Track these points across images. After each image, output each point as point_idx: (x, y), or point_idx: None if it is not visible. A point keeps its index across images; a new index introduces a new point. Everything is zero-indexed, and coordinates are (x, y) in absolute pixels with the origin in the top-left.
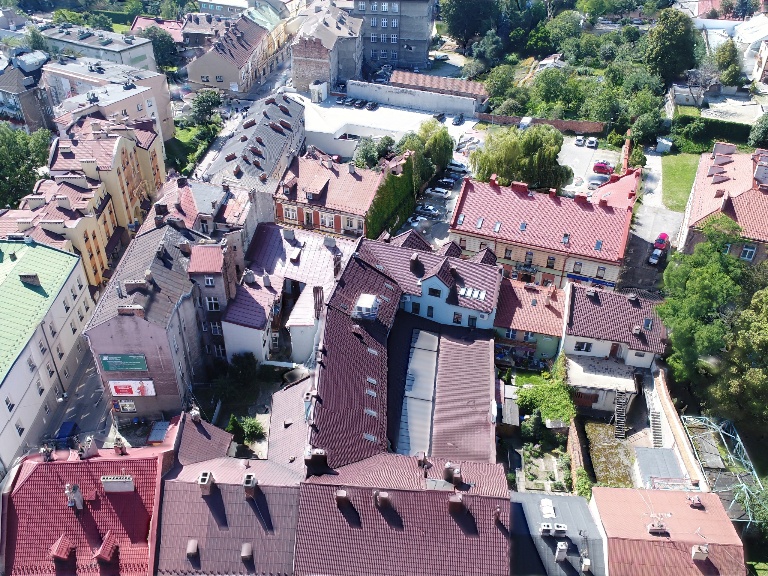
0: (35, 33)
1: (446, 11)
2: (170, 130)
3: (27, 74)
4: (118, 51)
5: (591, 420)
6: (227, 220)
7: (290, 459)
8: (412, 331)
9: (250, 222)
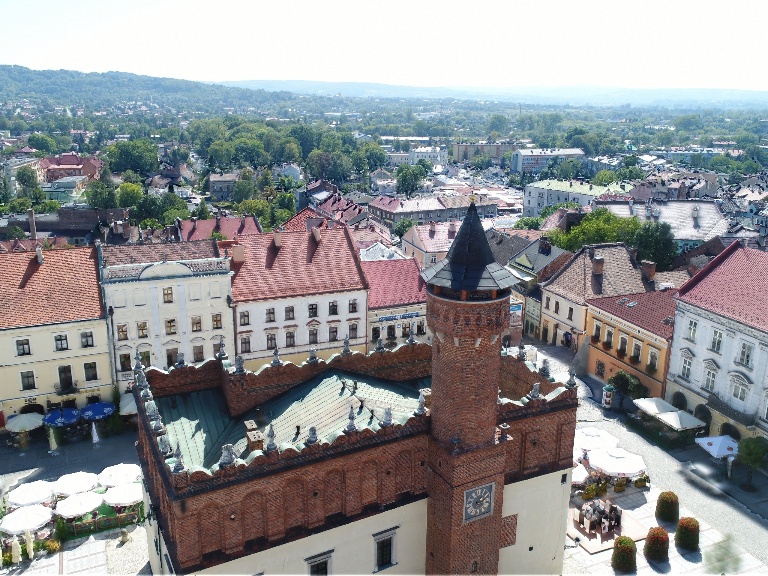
0: None
1: None
2: None
3: None
4: None
5: None
6: (693, 188)
7: None
8: None
9: (702, 191)
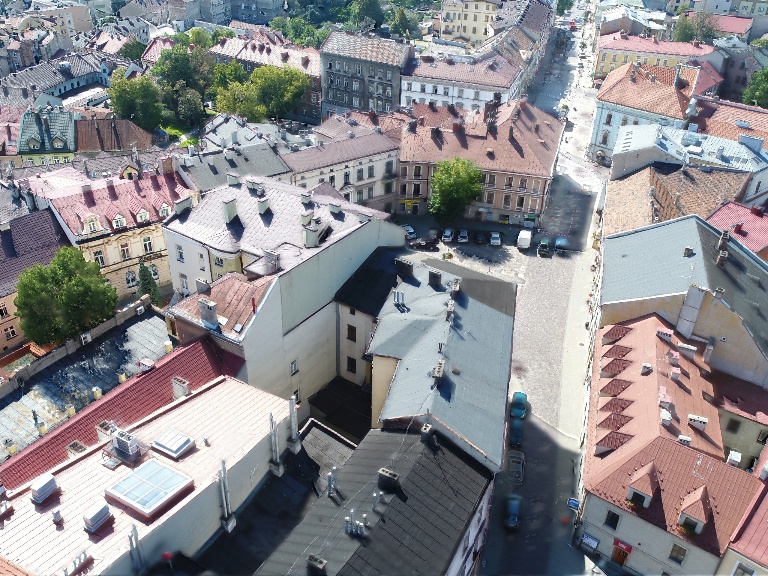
0: None
1: None
2: None
3: (26, 3)
4: (86, 0)
5: None
6: (43, 43)
7: None
8: (95, 87)
9: (53, 45)
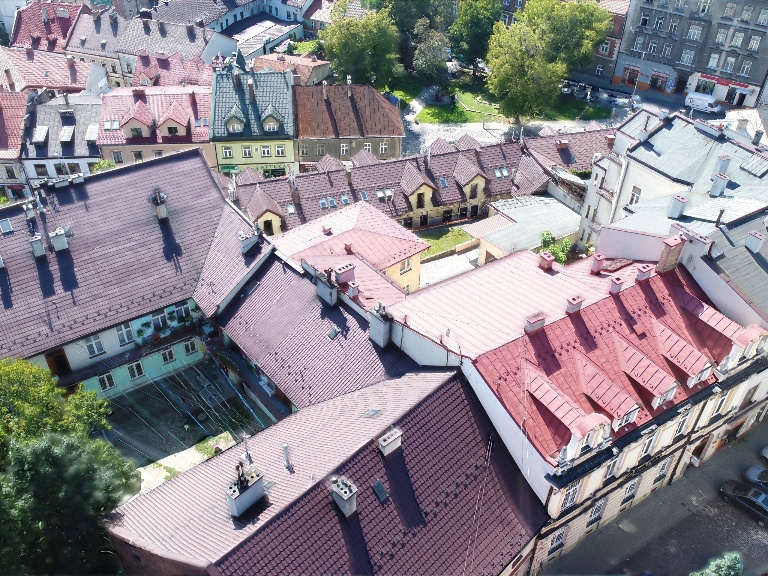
0: None
1: None
2: None
3: None
4: None
5: None
6: None
7: None
8: (263, 20)
9: None
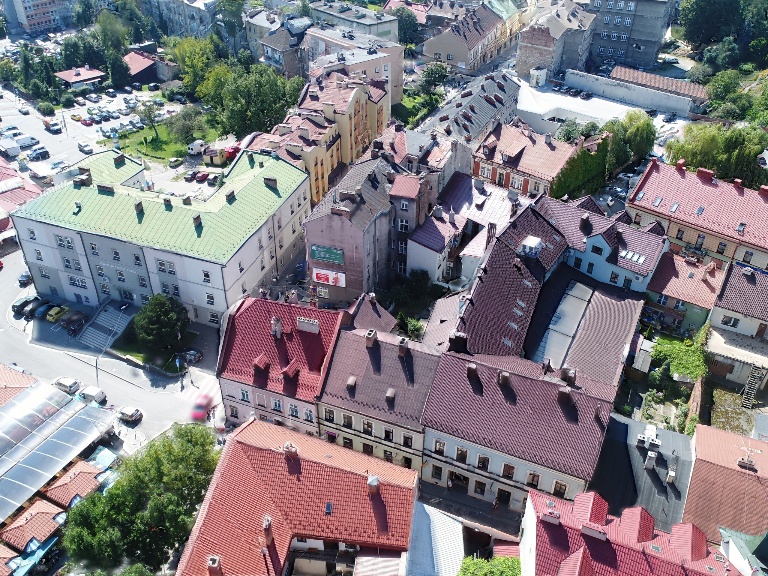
0: (305, 4)
1: (685, 15)
2: (398, 96)
3: (293, 35)
4: (368, 24)
5: (722, 387)
6: (429, 163)
7: (439, 342)
8: (570, 281)
9: (448, 168)
